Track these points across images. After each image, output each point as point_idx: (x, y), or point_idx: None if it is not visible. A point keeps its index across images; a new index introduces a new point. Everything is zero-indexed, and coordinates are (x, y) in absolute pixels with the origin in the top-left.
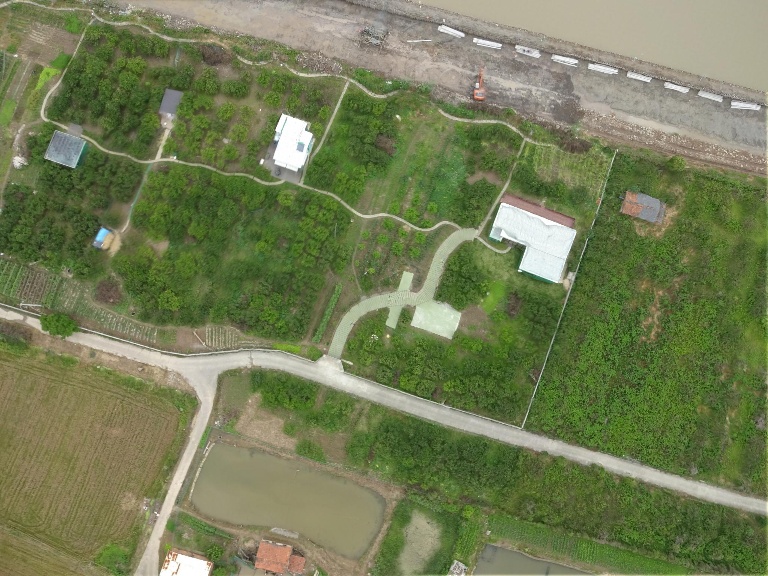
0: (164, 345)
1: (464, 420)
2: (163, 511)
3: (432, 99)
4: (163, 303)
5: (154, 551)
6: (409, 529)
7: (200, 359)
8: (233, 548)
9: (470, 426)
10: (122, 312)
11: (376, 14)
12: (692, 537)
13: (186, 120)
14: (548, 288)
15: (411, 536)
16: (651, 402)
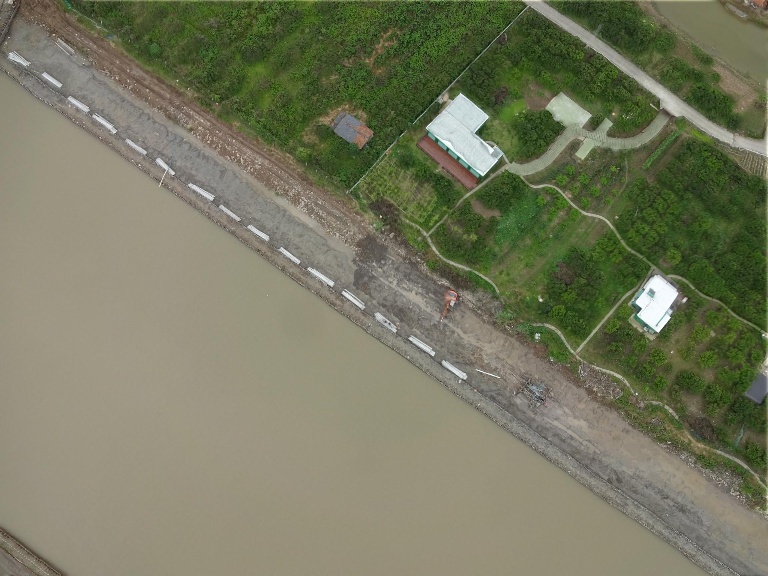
0: None
1: (573, 30)
2: None
3: (502, 304)
4: None
5: None
6: None
7: None
8: None
9: (569, 24)
10: None
11: (522, 418)
12: None
13: (750, 362)
14: None
15: None
16: None
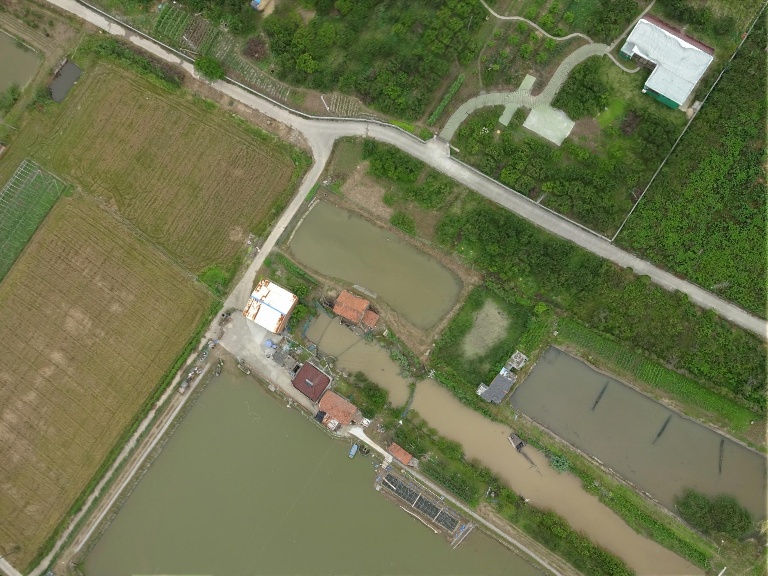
0: (293, 104)
1: (555, 223)
2: (264, 248)
3: None
4: (300, 63)
5: (249, 280)
6: (480, 314)
7: (322, 123)
8: (317, 295)
9: (560, 230)
10: (263, 68)
11: None
12: (767, 381)
13: None
14: (670, 114)
15: (480, 321)
16: (754, 243)
